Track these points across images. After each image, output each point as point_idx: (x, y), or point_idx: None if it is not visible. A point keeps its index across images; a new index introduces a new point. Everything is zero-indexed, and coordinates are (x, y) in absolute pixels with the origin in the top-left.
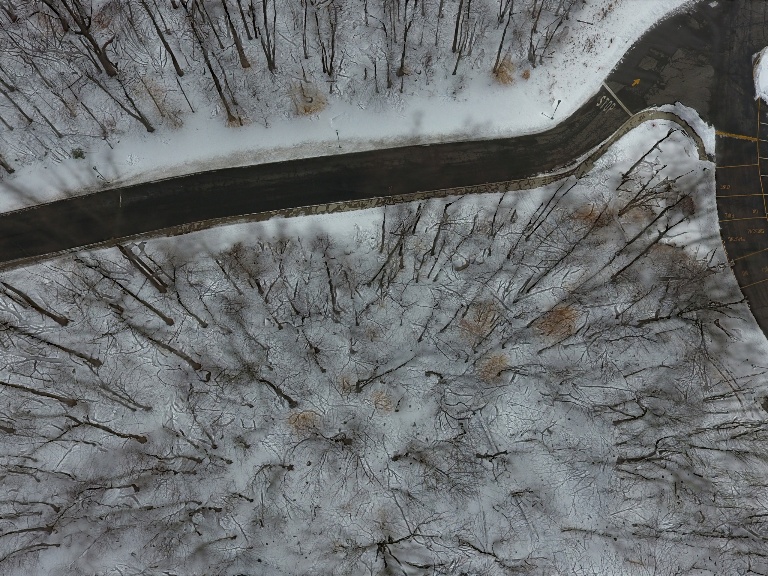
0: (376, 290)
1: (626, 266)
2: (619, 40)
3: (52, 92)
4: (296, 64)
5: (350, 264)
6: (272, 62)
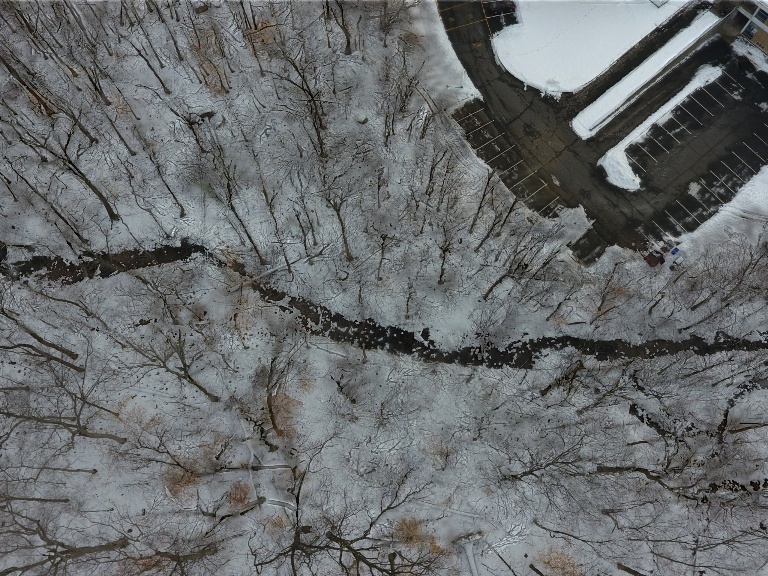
0: (127, 28)
1: None
2: None
3: None
4: None
5: (107, 8)
6: None
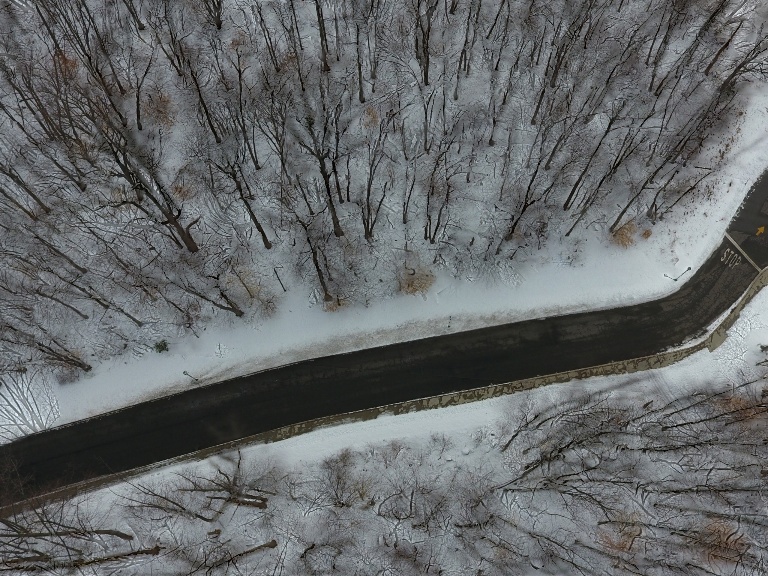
0: (500, 497)
1: None
2: (738, 182)
3: (135, 285)
4: (394, 230)
5: (470, 467)
6: (369, 231)
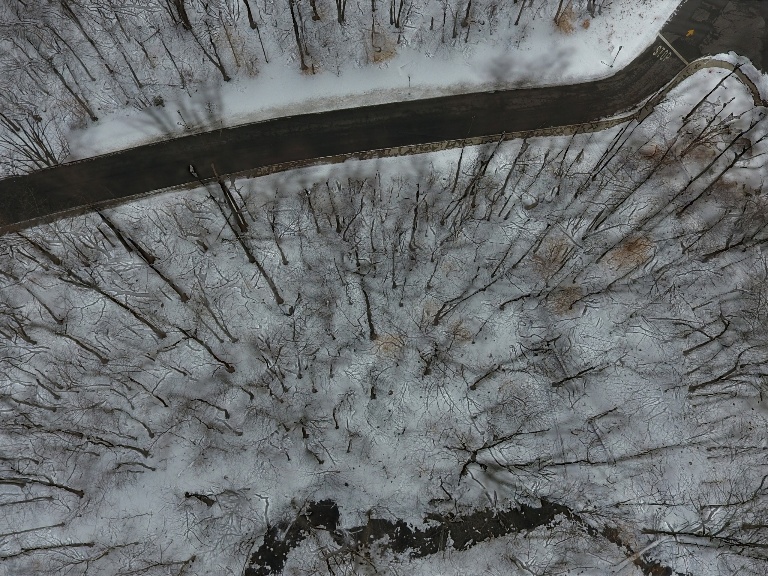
0: (449, 228)
1: (694, 200)
2: None
3: None
4: (364, 16)
5: None
6: (342, 14)
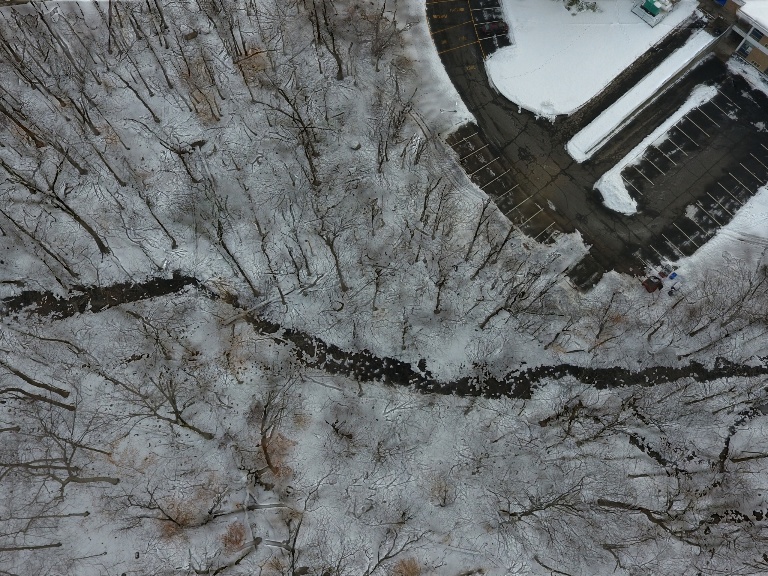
0: (116, 56)
1: None
2: None
3: None
4: None
5: (94, 36)
6: None
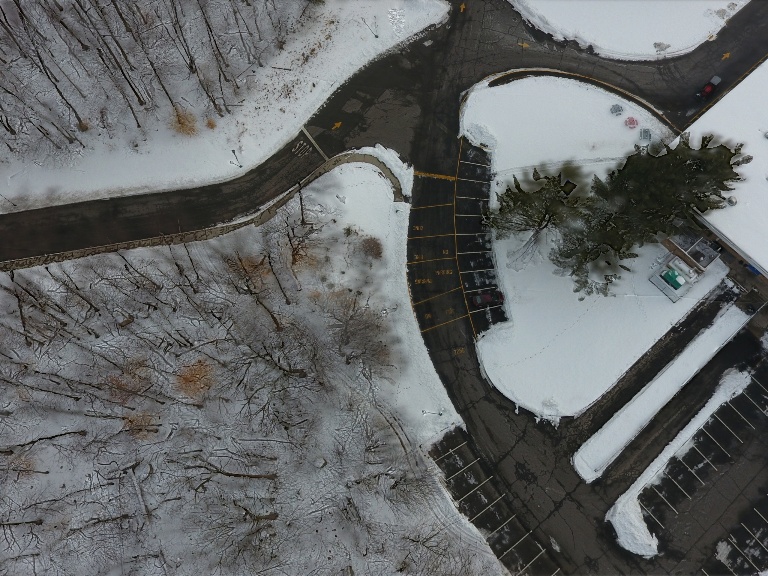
0: (35, 349)
1: None
2: (324, 84)
3: None
4: None
5: (10, 324)
6: None
